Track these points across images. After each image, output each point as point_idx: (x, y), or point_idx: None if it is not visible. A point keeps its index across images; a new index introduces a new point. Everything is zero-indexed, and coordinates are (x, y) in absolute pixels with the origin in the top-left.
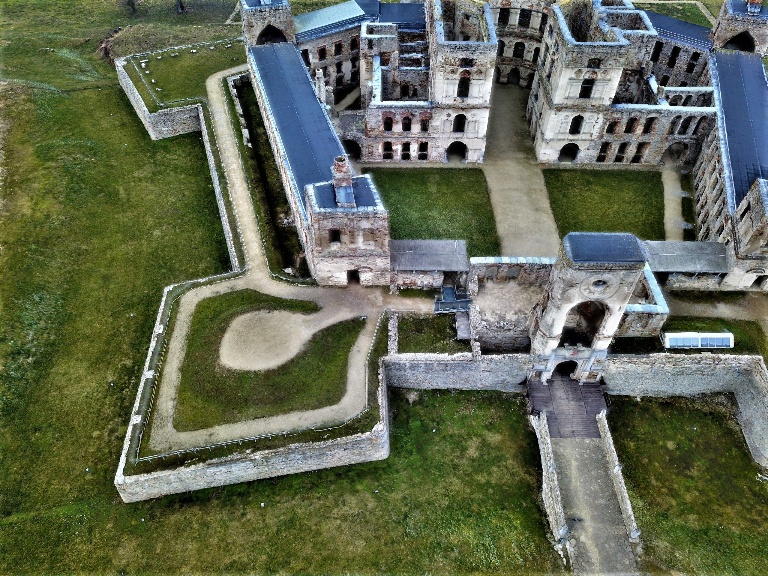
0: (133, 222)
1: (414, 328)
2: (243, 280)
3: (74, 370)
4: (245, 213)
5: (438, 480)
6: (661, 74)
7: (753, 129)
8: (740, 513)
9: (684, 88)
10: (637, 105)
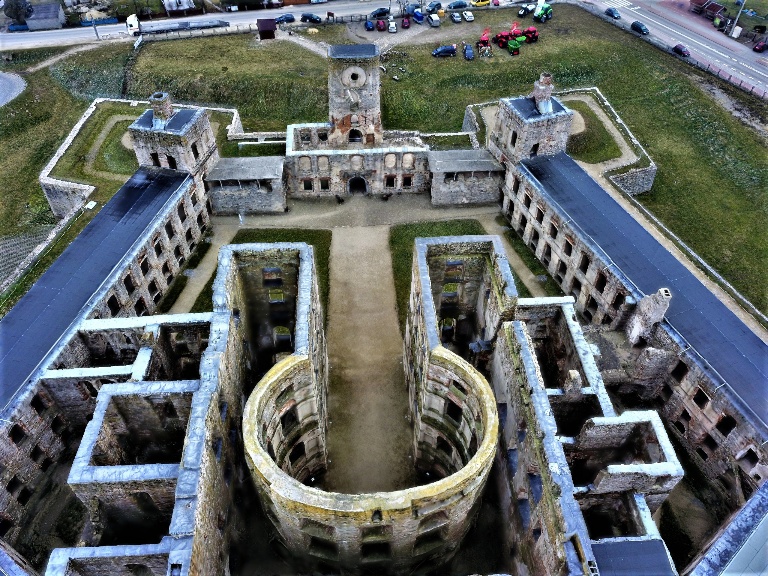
0: (763, 262)
1: (460, 146)
2: (601, 170)
3: (679, 150)
4: (643, 225)
5: (432, 128)
6: (25, 565)
7: (75, 273)
8: (270, 125)
9: (93, 371)
10: (197, 317)
